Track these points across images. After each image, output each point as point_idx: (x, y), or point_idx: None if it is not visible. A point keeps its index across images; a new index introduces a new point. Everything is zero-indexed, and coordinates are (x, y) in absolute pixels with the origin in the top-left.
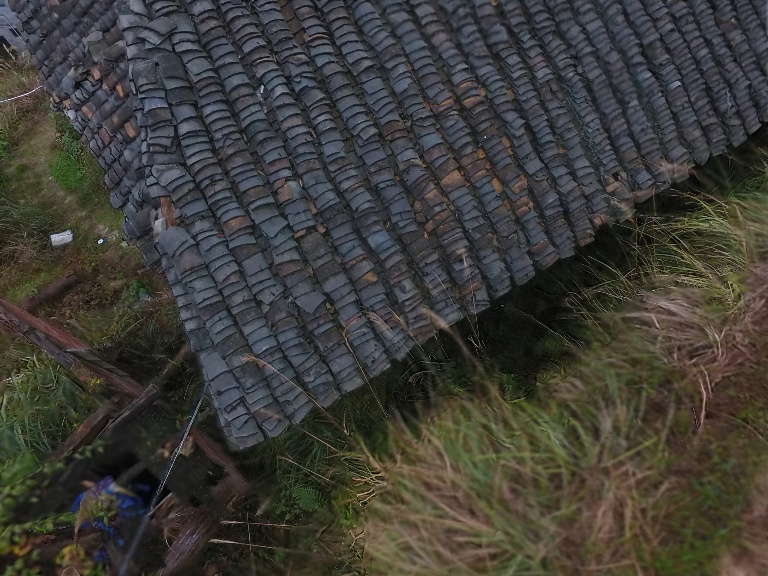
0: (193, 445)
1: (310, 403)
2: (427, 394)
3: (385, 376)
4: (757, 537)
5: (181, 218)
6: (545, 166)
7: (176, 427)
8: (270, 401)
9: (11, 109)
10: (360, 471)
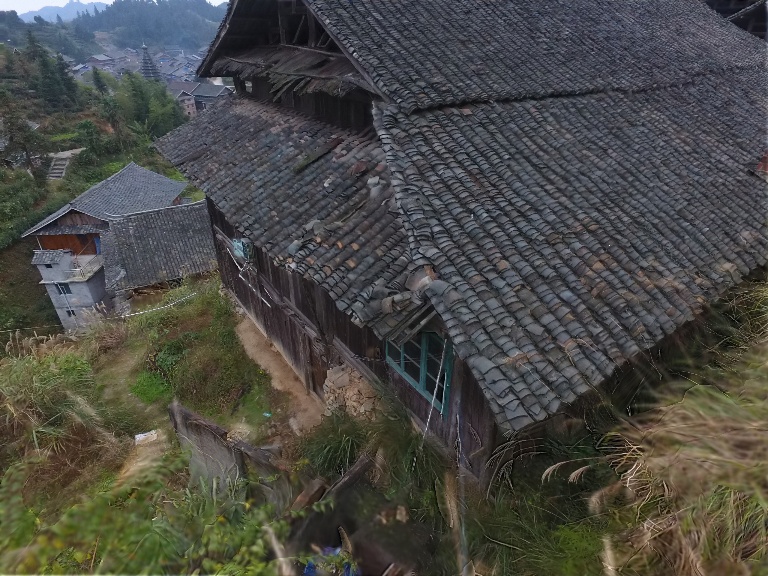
0: (407, 513)
1: (558, 399)
2: (592, 491)
3: (604, 386)
4: None
5: (410, 300)
6: (651, 265)
7: (386, 499)
8: (530, 393)
9: (95, 347)
10: (619, 448)
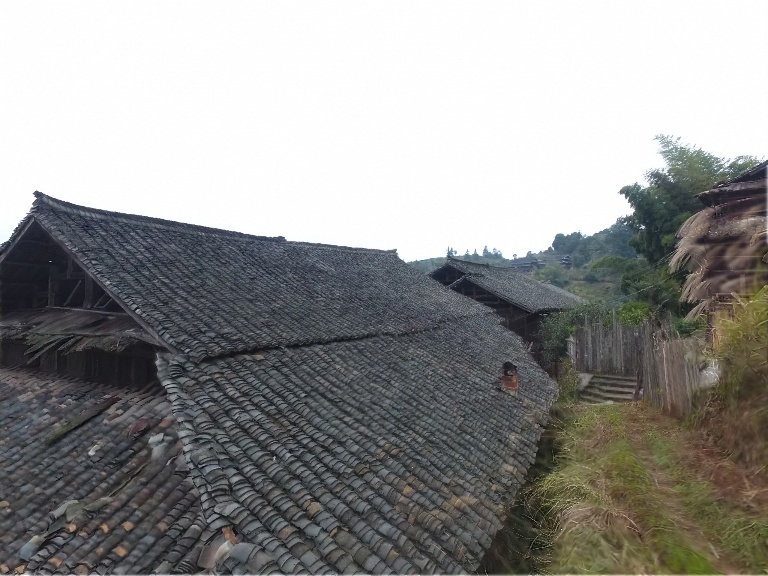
0: None
1: None
2: None
3: None
4: (722, 568)
5: None
6: None
7: None
8: None
9: None
10: None
